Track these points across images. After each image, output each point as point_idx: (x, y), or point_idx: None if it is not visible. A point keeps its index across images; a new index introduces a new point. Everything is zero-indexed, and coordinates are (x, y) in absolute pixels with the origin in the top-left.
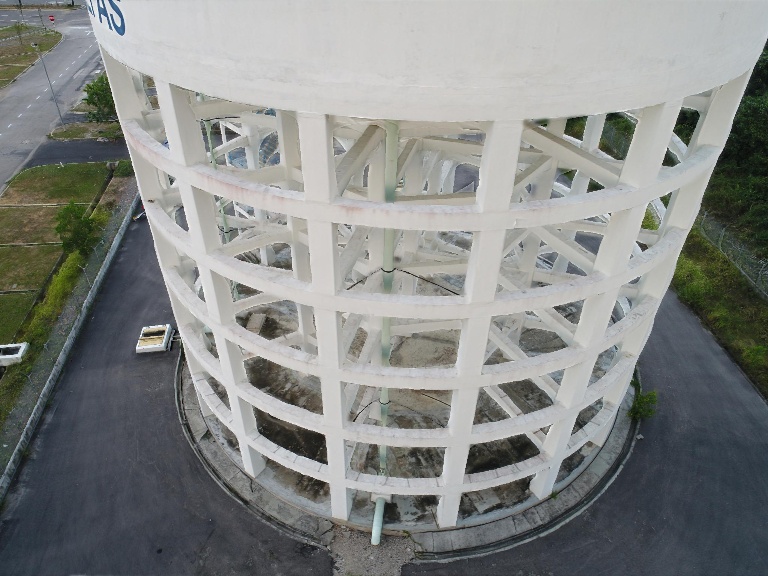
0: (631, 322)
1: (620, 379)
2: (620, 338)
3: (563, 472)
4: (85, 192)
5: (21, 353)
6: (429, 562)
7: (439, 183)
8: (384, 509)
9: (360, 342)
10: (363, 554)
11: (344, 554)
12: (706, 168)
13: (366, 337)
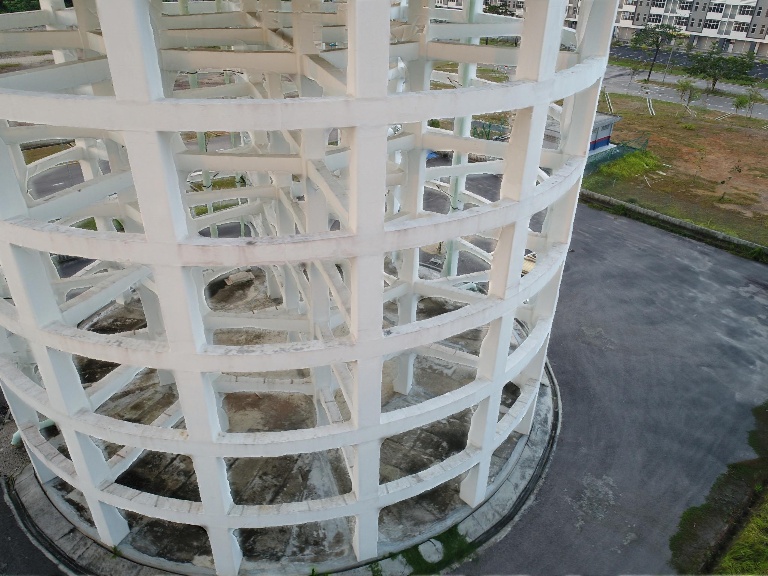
0: (97, 341)
1: (150, 447)
2: (77, 349)
3: (154, 548)
4: None
5: None
6: (3, 488)
7: None
8: (46, 427)
9: (258, 333)
10: (5, 443)
11: (3, 432)
12: (87, 122)
13: (268, 334)
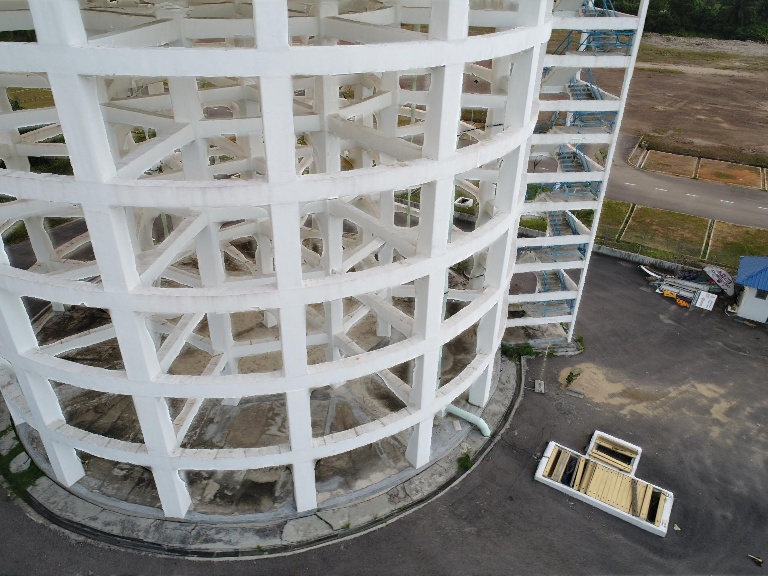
0: None
1: None
2: None
3: (49, 324)
4: (736, 259)
5: (456, 203)
6: None
7: (324, 251)
8: None
9: None
10: None
11: None
12: None
13: None
